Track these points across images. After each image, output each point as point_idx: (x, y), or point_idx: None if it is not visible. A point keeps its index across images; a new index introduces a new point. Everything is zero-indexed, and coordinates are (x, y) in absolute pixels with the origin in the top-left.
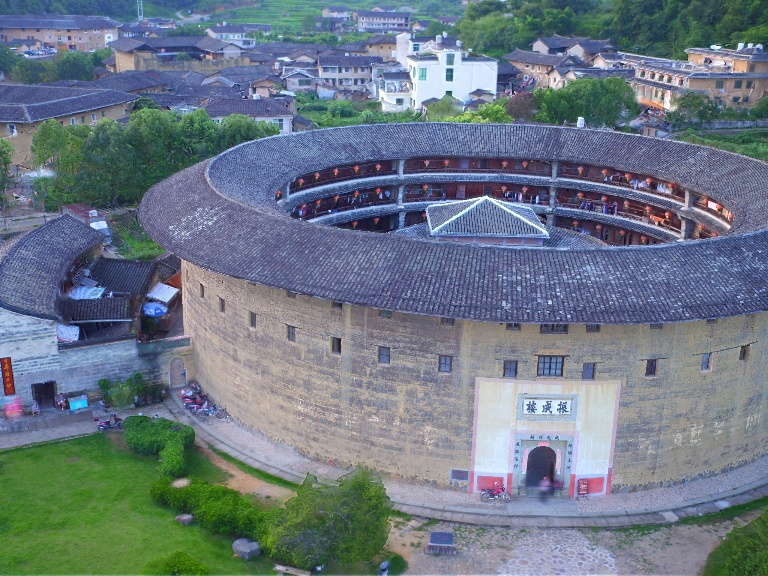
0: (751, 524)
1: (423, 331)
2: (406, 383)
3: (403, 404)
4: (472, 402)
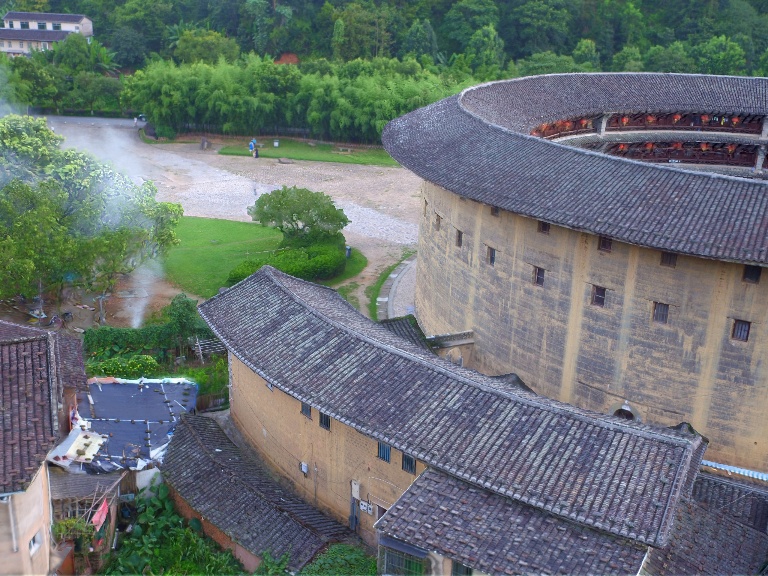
0: (339, 212)
1: None
2: None
3: None
4: None
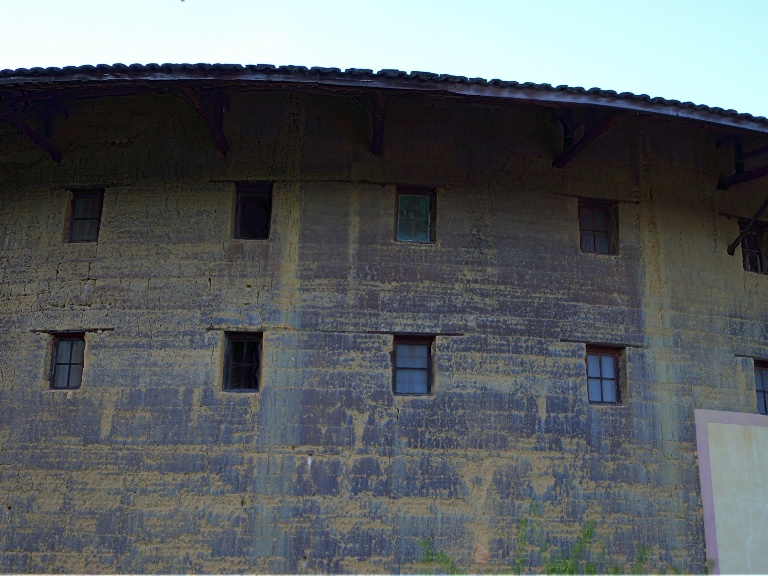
0: None
1: (534, 272)
2: (492, 448)
3: (485, 527)
4: (694, 494)
